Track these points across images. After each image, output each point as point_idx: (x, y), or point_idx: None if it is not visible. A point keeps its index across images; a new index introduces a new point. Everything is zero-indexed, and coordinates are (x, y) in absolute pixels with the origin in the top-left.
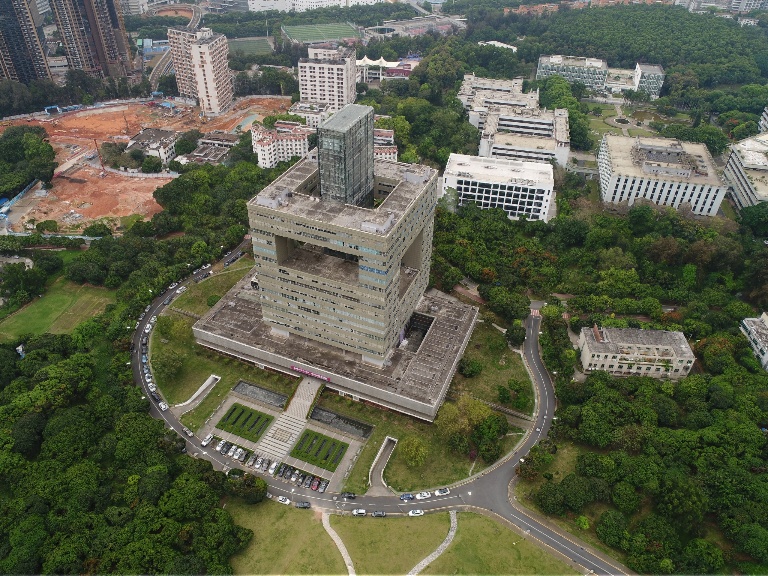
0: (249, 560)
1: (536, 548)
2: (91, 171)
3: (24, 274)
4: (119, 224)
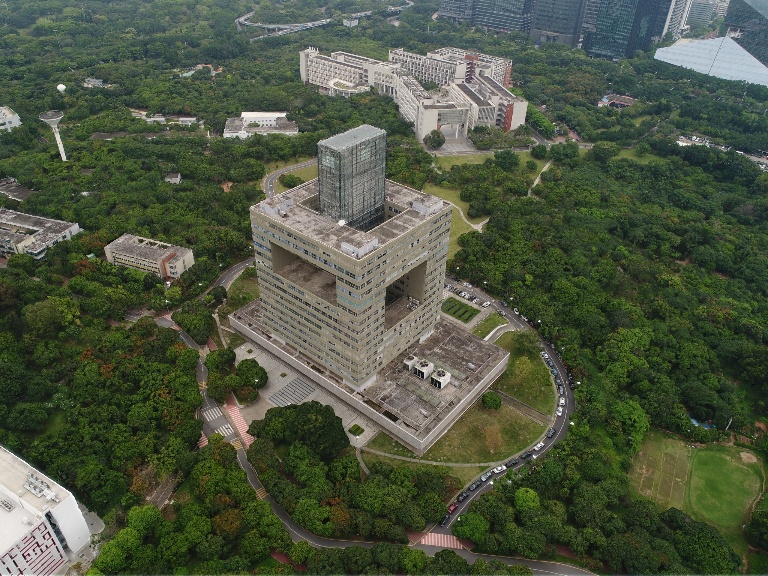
0: None
1: None
2: None
3: None
4: None
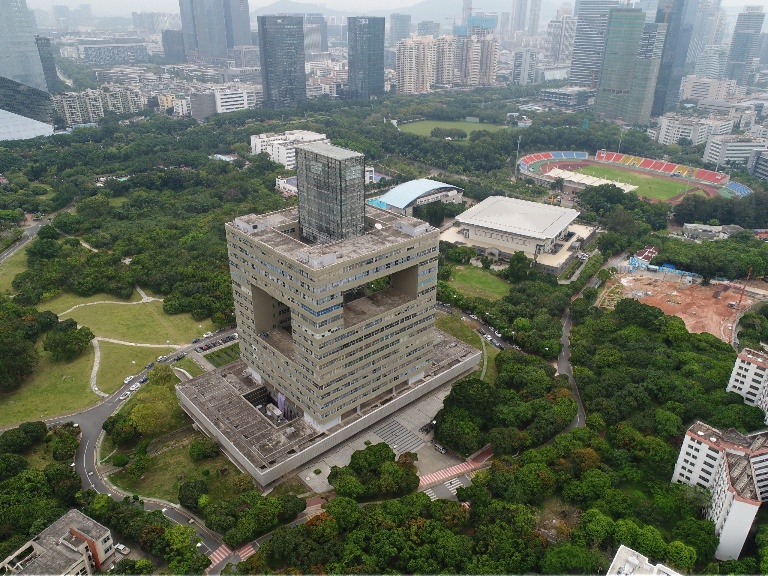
0: (186, 318)
1: (28, 419)
2: (747, 302)
3: (519, 263)
4: (611, 308)
